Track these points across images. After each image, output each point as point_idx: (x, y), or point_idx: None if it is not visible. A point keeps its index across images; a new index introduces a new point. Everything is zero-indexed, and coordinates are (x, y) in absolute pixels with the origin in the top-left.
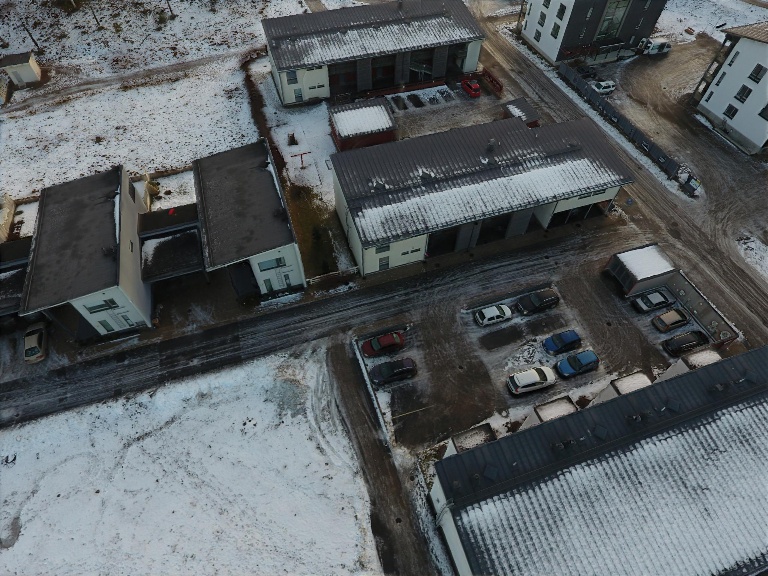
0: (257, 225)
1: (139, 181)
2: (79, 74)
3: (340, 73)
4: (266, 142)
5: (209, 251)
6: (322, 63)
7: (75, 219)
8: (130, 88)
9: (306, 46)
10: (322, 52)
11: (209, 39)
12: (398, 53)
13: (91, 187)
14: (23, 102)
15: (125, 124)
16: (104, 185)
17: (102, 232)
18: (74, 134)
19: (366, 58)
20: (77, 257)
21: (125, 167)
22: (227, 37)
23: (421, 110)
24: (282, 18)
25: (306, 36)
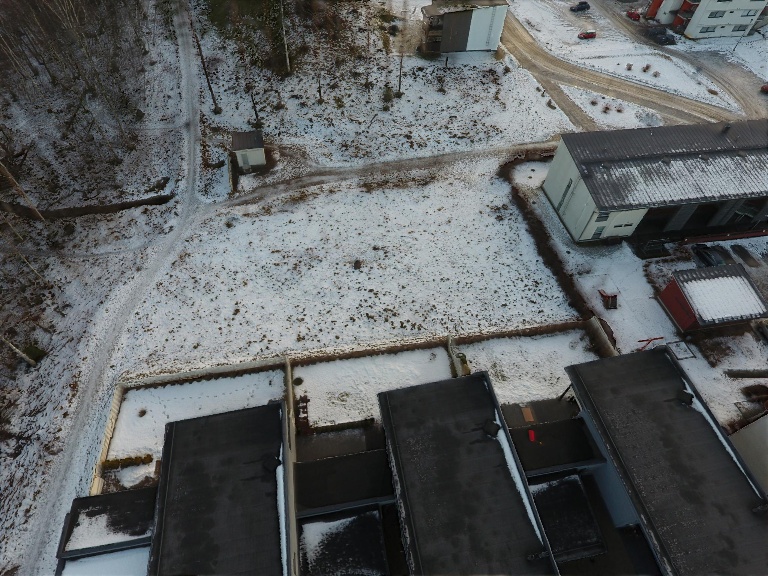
0: (732, 528)
1: (437, 347)
2: (307, 159)
3: (650, 209)
4: (671, 354)
5: (674, 571)
6: (652, 205)
7: (451, 467)
8: (372, 187)
9: (626, 178)
10: (648, 189)
11: (447, 128)
12: (741, 198)
13: (452, 404)
14: (252, 192)
15: (384, 243)
16: (471, 405)
17: (504, 506)
18: (326, 251)
19: (703, 202)
20: (483, 555)
21: (402, 313)
22: (467, 128)
23: (758, 272)
24: (586, 134)
25: (622, 163)
